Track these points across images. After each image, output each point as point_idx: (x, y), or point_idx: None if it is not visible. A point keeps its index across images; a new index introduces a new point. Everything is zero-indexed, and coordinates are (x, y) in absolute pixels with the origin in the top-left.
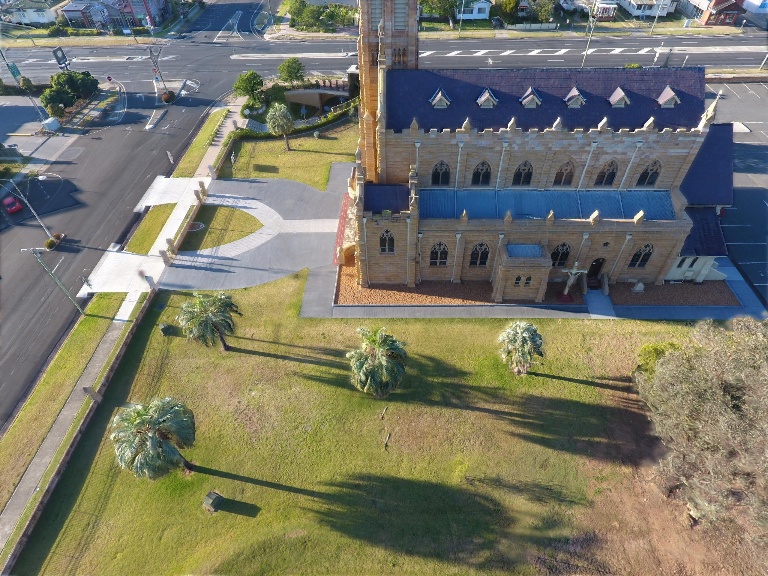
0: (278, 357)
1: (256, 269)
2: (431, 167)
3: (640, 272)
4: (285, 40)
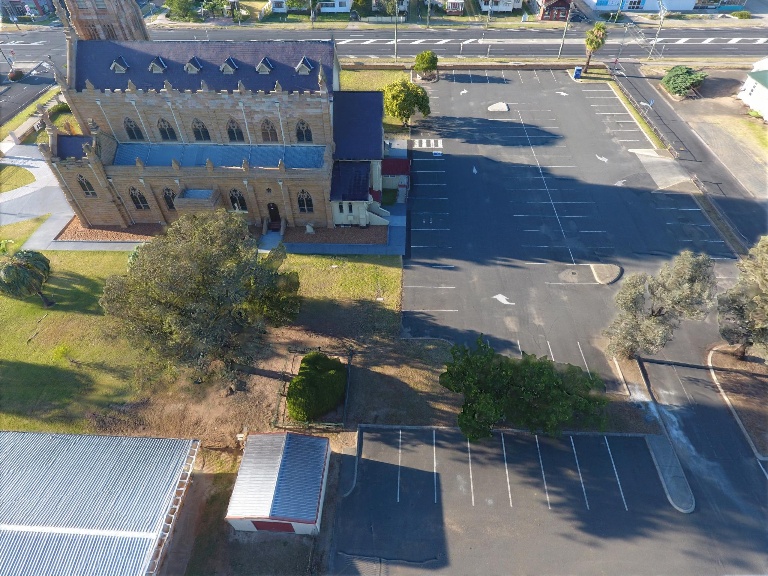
0: None
1: (7, 214)
2: (121, 123)
3: (311, 216)
4: (154, 29)
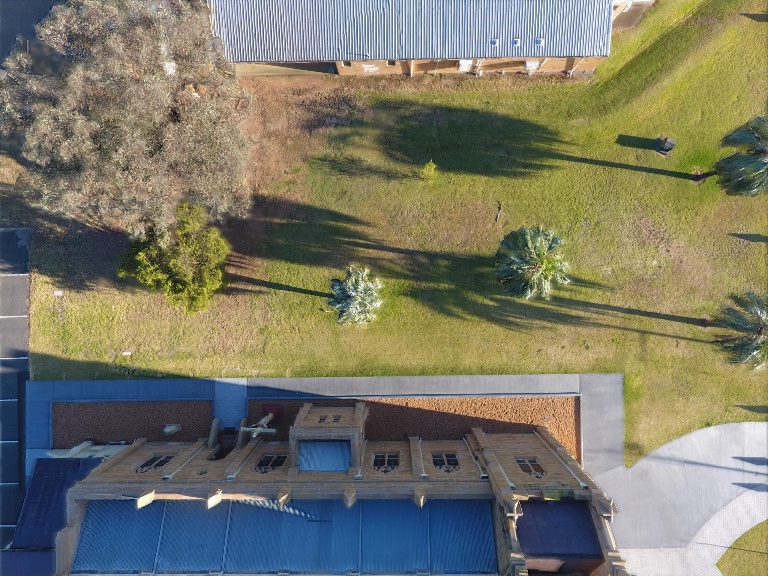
0: (637, 312)
1: (703, 464)
2: None
3: (162, 450)
4: None
